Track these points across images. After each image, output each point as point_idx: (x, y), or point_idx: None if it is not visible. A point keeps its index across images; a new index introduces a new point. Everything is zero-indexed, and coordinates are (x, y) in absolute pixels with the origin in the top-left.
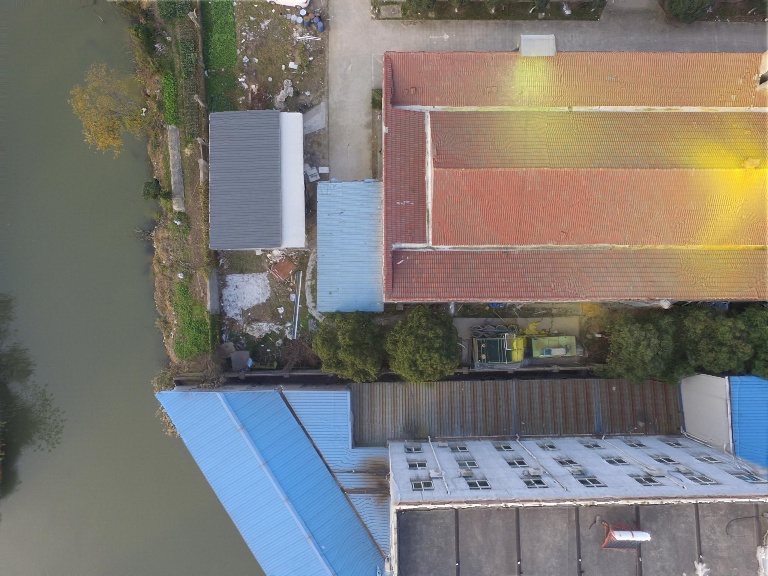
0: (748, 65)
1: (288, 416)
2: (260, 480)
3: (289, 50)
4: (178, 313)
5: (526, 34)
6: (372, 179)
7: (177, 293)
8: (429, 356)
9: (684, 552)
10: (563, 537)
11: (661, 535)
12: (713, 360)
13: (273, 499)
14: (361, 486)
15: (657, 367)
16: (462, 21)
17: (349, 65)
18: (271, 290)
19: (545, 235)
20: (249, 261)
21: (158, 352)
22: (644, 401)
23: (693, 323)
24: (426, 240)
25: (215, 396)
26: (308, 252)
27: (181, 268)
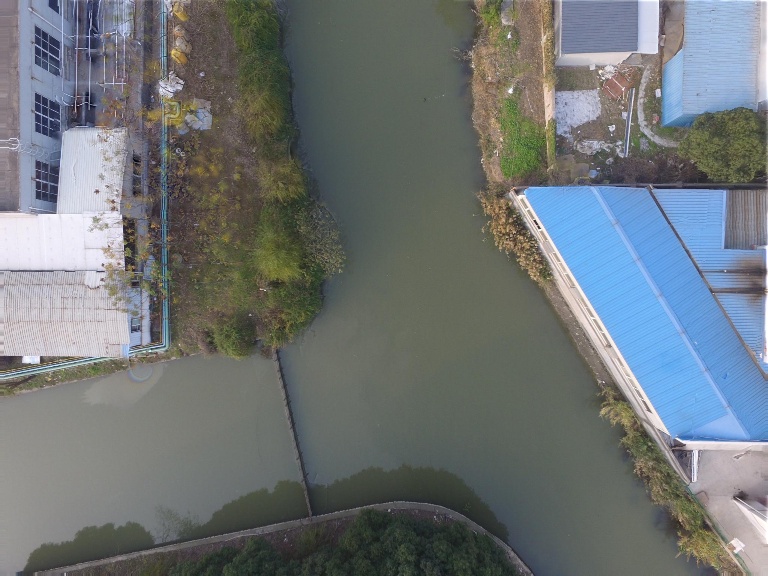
0: None
1: (658, 215)
2: (632, 276)
3: None
4: (505, 130)
5: None
6: None
7: (506, 109)
8: None
9: None
10: None
11: None
12: None
13: (645, 295)
14: (733, 286)
15: None
16: None
17: None
18: (602, 107)
19: None
20: (579, 77)
21: (474, 174)
22: None
23: None
24: None
25: (589, 191)
26: (641, 69)
27: (510, 83)
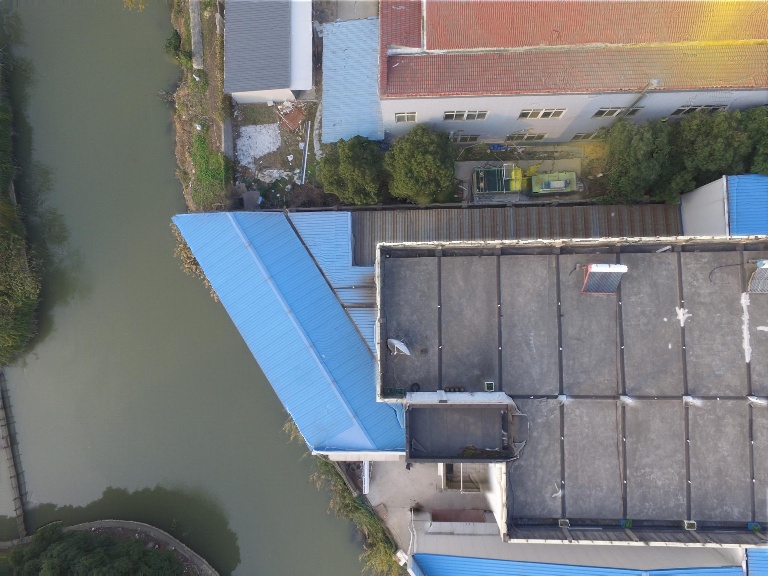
0: None
1: (293, 237)
2: (266, 294)
3: None
4: (196, 163)
5: None
6: (375, 16)
7: (195, 144)
8: (423, 159)
9: (665, 298)
10: (543, 283)
11: (642, 282)
12: (709, 155)
13: (277, 311)
14: (360, 301)
15: (651, 168)
16: None
17: None
18: (281, 139)
19: (538, 37)
20: (261, 113)
21: (178, 204)
22: (644, 226)
23: (689, 121)
24: (421, 45)
25: (225, 216)
26: (316, 103)
27: (199, 121)
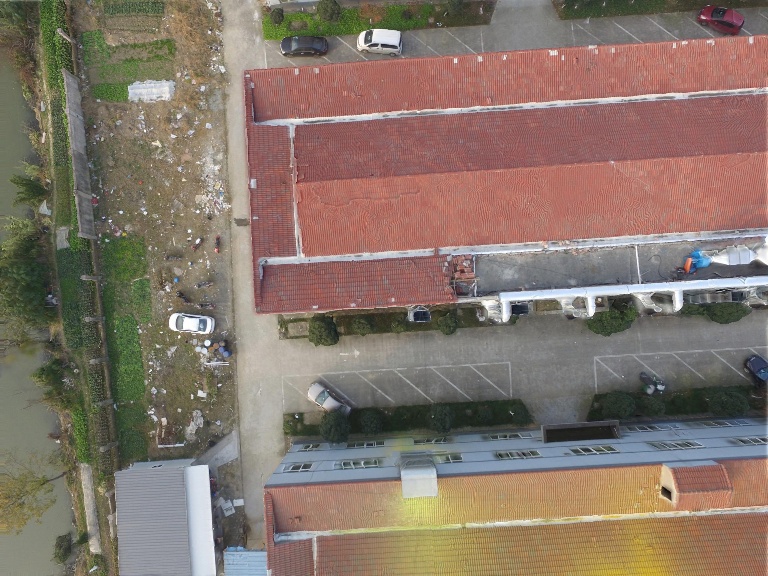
0: (646, 481)
1: None
2: None
3: (197, 379)
4: None
5: (439, 345)
6: None
7: None
8: None
9: None
10: None
11: None
12: None
13: None
14: None
15: None
16: (372, 335)
17: (259, 389)
18: None
19: None
20: None
21: None
22: None
23: None
24: None
25: None
26: None
27: None
